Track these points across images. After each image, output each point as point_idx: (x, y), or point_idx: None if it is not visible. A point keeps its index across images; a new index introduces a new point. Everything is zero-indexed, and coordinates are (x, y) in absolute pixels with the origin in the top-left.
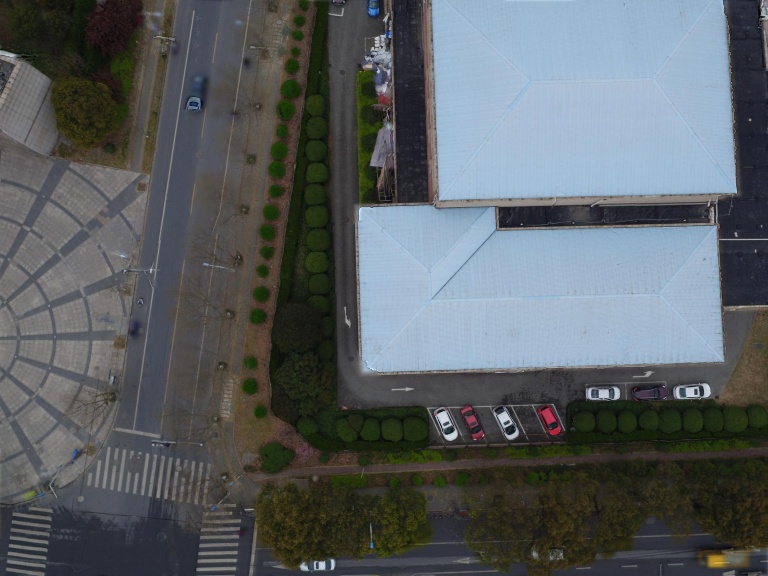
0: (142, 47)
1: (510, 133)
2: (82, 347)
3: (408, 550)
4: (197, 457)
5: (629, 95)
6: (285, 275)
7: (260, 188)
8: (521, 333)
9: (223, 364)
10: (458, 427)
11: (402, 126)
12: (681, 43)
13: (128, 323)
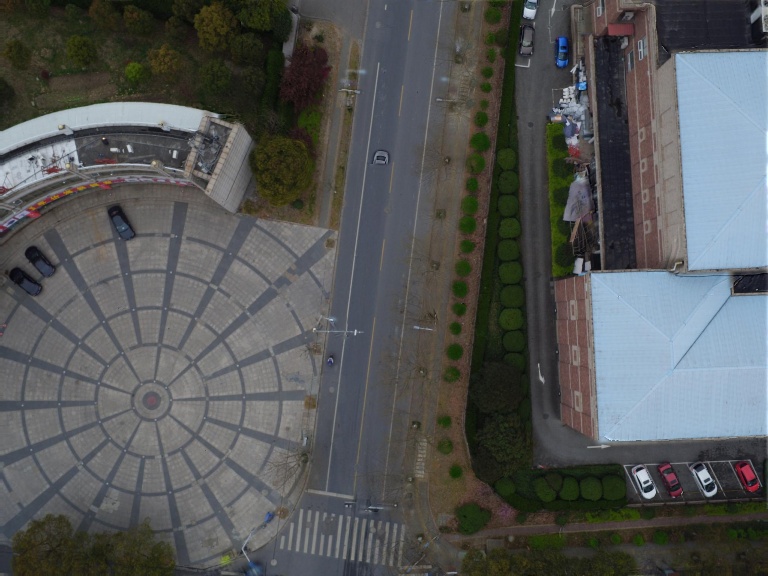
0: (327, 100)
1: (764, 203)
2: (272, 407)
3: None
4: (391, 518)
5: None
6: (480, 333)
7: (450, 243)
8: (762, 401)
9: (417, 423)
10: (655, 484)
11: (607, 183)
12: None
13: (319, 382)
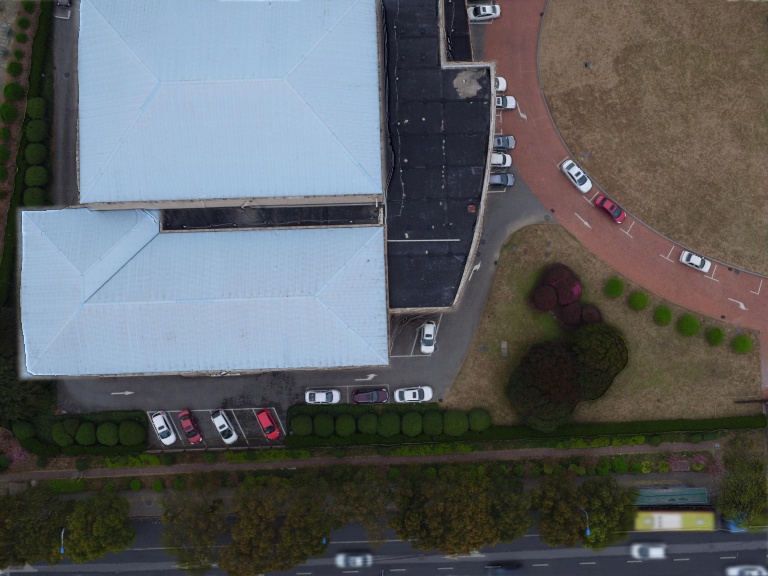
0: None
1: (145, 135)
2: None
3: (126, 555)
4: None
5: (261, 95)
6: (2, 279)
7: None
8: (178, 336)
9: None
10: (178, 431)
11: None
12: (319, 42)
13: None
